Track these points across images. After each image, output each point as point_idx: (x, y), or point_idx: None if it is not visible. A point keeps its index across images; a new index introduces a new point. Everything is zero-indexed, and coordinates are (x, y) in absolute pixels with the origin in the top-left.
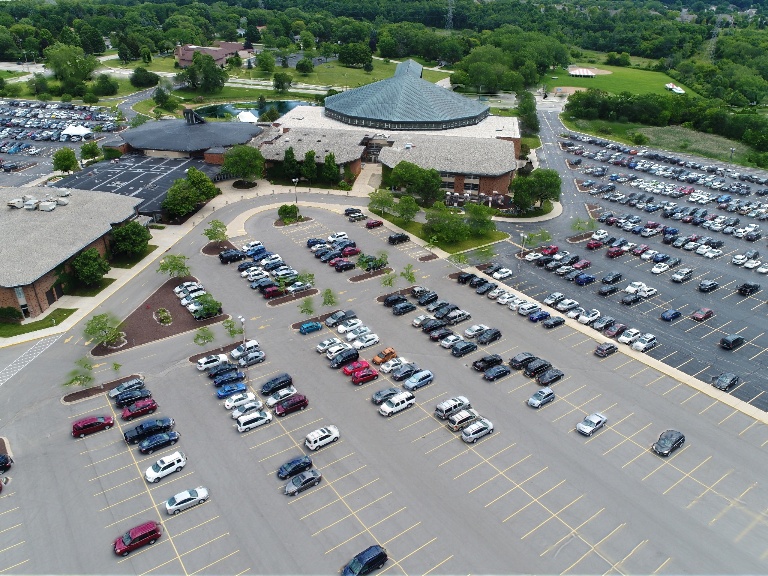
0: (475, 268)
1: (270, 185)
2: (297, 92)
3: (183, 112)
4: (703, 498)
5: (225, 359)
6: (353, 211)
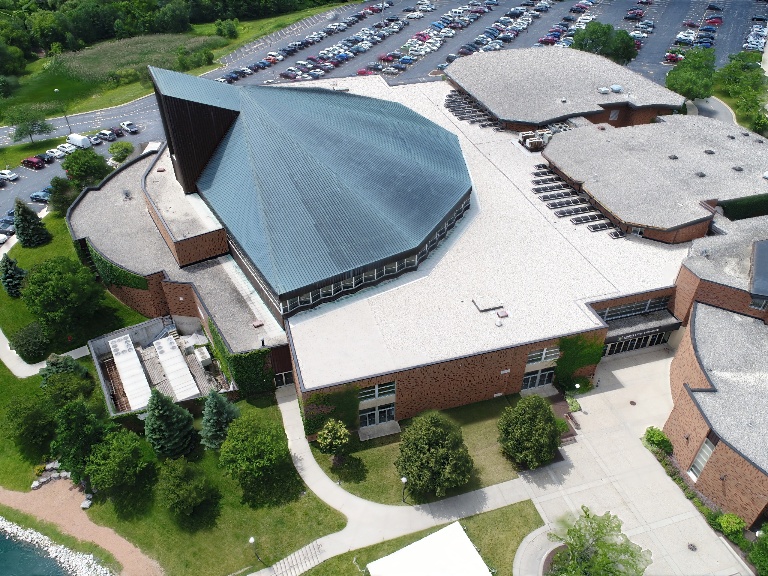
0: None
1: None
2: None
3: None
4: None
5: None
6: None
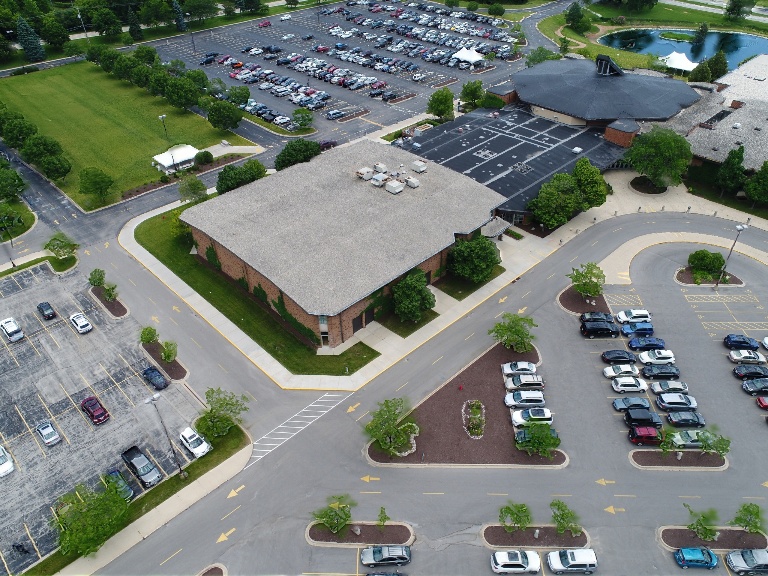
0: None
1: (686, 194)
2: (757, 21)
3: (597, 58)
4: None
5: (536, 568)
6: None
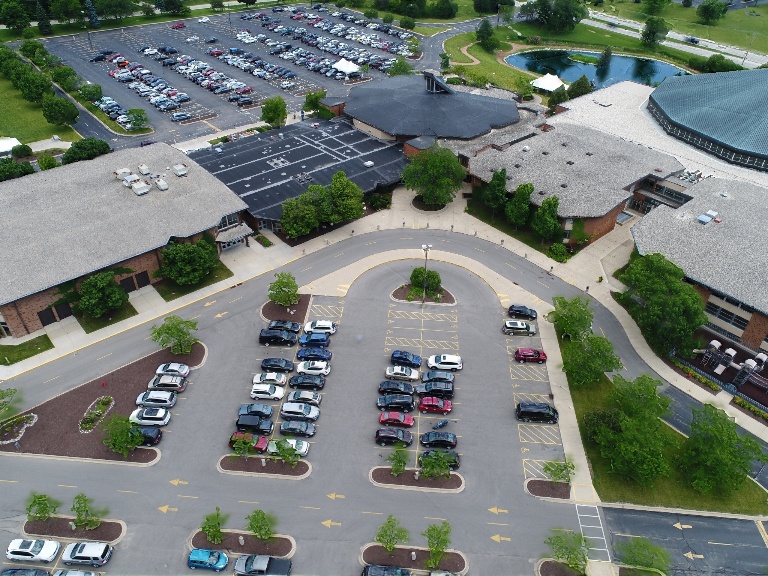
0: (615, 572)
1: (462, 213)
2: (673, 47)
3: (424, 75)
4: None
5: (45, 557)
6: (522, 313)
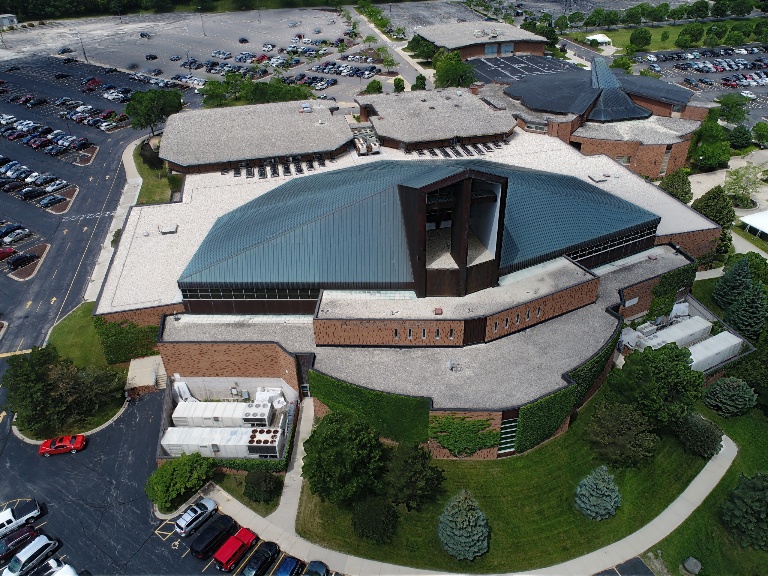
0: None
1: None
2: None
3: None
4: (150, 53)
5: None
6: None
